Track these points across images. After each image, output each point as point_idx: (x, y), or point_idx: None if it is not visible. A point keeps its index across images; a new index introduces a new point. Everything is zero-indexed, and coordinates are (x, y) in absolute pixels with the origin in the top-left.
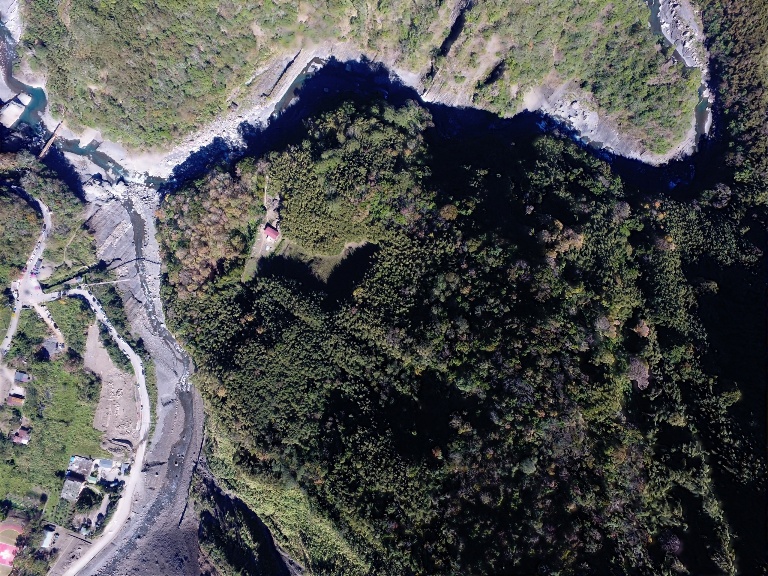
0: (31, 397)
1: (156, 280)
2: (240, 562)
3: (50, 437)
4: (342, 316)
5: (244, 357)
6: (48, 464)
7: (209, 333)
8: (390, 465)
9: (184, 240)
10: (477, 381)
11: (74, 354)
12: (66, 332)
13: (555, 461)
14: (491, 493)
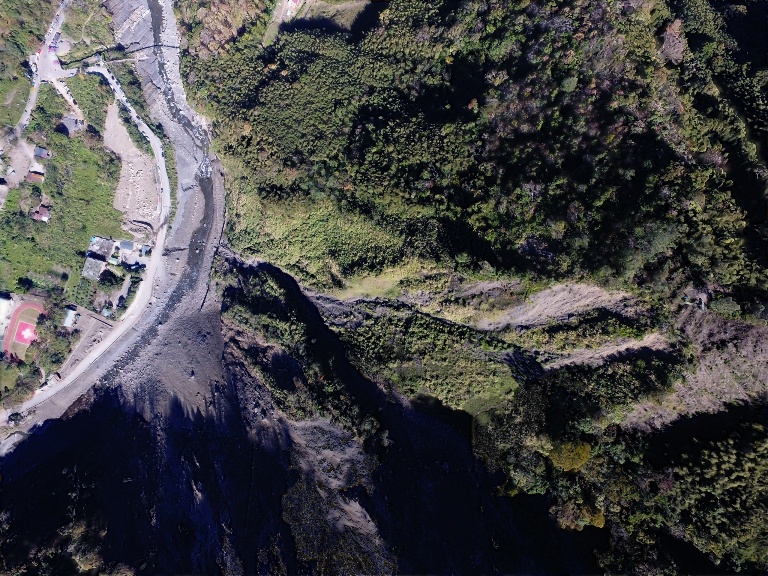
0: (51, 172)
1: (175, 65)
2: (266, 310)
3: (70, 215)
4: (368, 41)
5: (269, 94)
6: (69, 242)
7: (232, 89)
8: (424, 136)
9: (205, 2)
10: (512, 36)
11: (94, 131)
12: (85, 108)
13: (596, 78)
14: (530, 124)
